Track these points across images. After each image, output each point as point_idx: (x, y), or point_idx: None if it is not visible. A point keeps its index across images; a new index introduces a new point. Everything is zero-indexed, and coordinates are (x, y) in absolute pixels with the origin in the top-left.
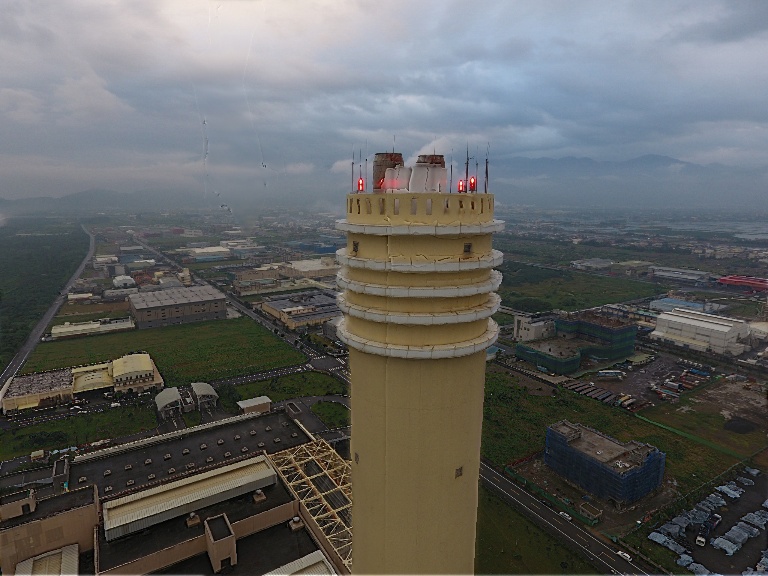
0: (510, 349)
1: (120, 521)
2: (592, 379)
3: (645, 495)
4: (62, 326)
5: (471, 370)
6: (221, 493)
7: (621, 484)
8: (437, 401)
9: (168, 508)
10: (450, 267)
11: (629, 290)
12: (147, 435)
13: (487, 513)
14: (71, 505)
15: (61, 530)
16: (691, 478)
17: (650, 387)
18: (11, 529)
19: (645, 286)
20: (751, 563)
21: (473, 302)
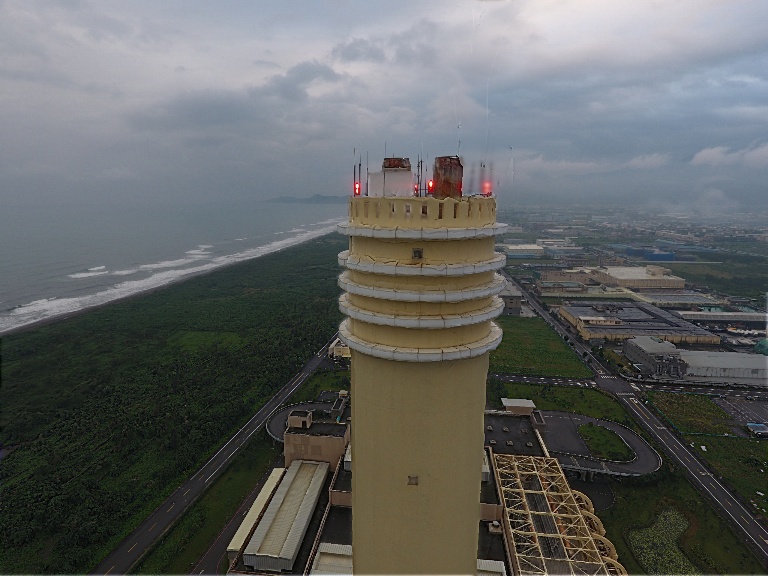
0: None
1: None
2: None
3: None
4: None
5: (428, 380)
6: None
7: None
8: (388, 400)
9: None
10: (386, 270)
11: None
12: None
13: None
14: (330, 433)
15: (321, 448)
16: None
17: None
18: (293, 434)
19: None
20: None
21: (429, 310)
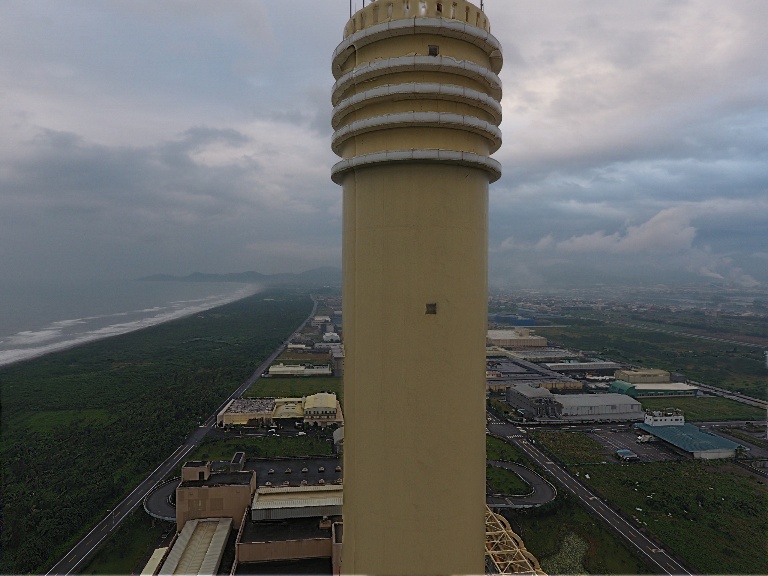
0: (760, 450)
1: (265, 505)
2: None
3: None
4: (277, 366)
5: (445, 190)
6: None
7: None
8: (401, 217)
9: (305, 505)
10: (404, 61)
11: None
12: None
13: None
14: (233, 482)
15: (222, 501)
16: None
17: None
18: (188, 488)
19: None
20: None
21: None
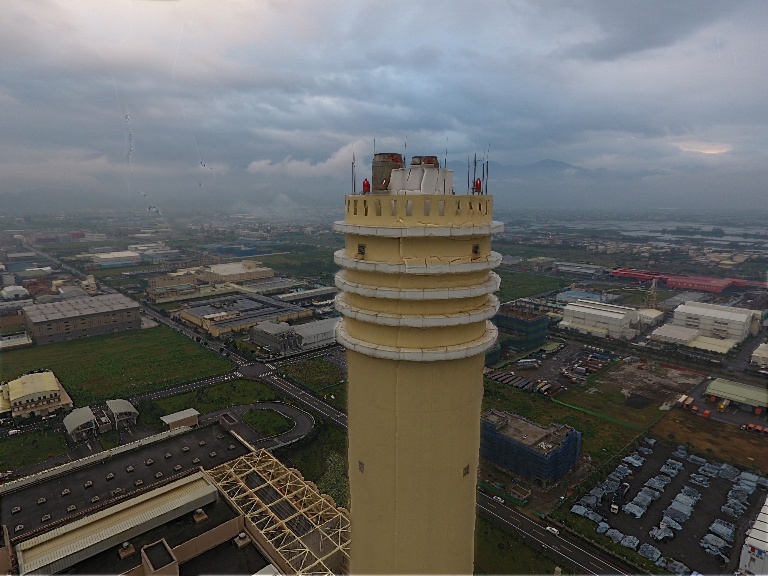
0: None
1: (39, 563)
2: (512, 369)
3: (566, 472)
4: None
5: (476, 369)
6: (157, 517)
7: (546, 464)
8: (448, 402)
9: (97, 541)
10: (464, 268)
11: (537, 284)
12: (57, 462)
13: None
14: None
15: None
16: (602, 452)
17: (562, 373)
18: None
19: (551, 280)
20: (655, 523)
21: (479, 302)
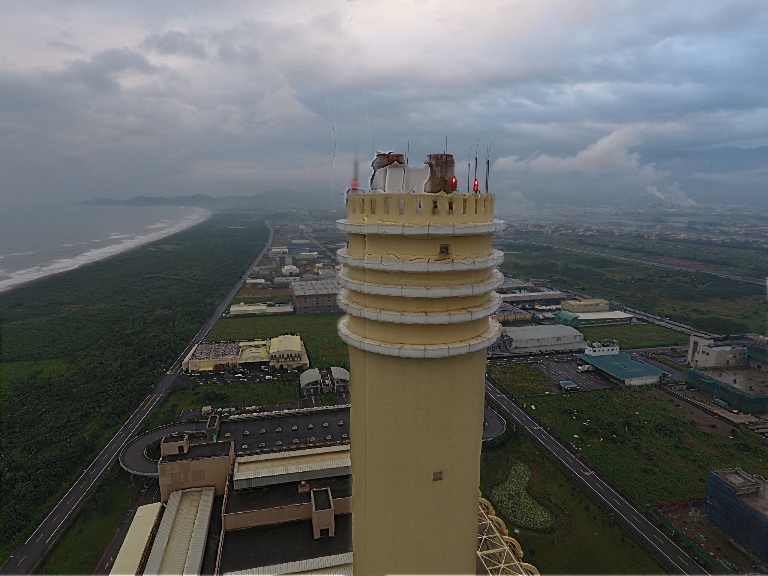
0: (680, 374)
1: (246, 475)
2: None
3: None
4: (238, 305)
5: (452, 374)
6: (330, 469)
7: None
8: (412, 400)
9: (284, 472)
10: (418, 267)
11: None
12: (289, 408)
13: (617, 554)
14: (212, 454)
15: (203, 472)
16: None
17: None
18: (169, 463)
19: None
20: None
21: (453, 305)
